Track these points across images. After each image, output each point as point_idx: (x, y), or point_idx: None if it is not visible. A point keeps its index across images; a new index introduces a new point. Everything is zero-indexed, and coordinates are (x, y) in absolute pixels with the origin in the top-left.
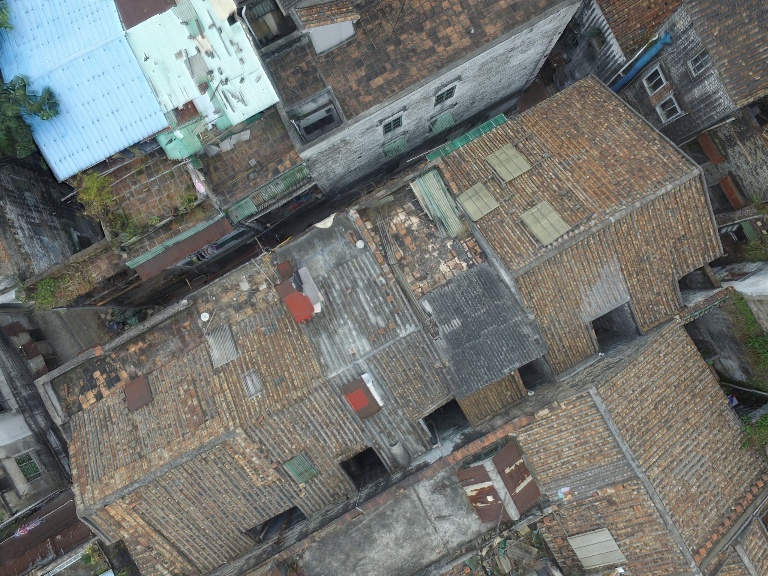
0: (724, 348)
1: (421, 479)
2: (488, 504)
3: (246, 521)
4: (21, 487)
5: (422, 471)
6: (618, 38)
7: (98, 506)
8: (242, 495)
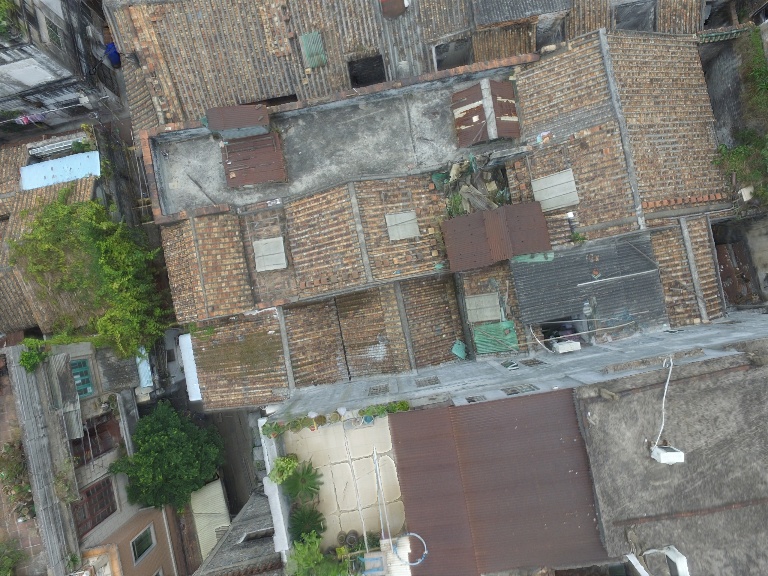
0: (722, 114)
1: (420, 81)
2: (472, 125)
3: (246, 92)
4: (44, 37)
5: (423, 74)
6: None
7: (124, 3)
8: (252, 59)
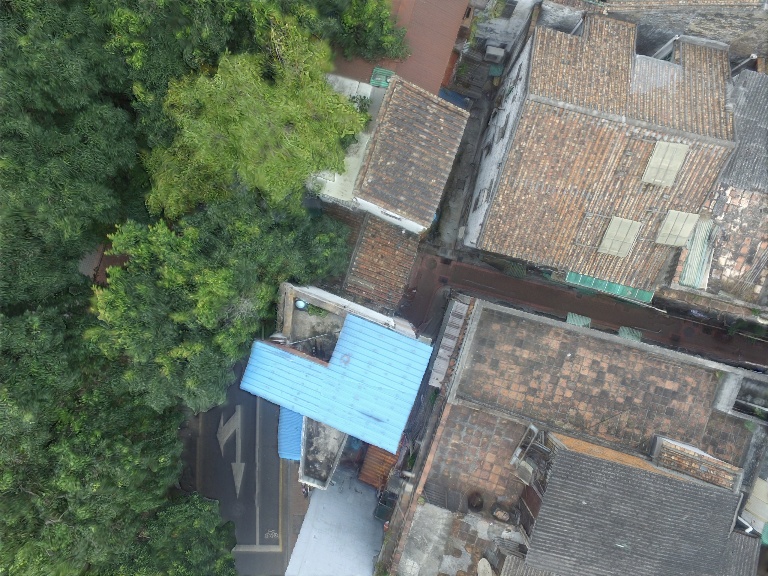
0: None
1: None
2: None
3: None
4: None
5: None
6: None
7: None
8: None
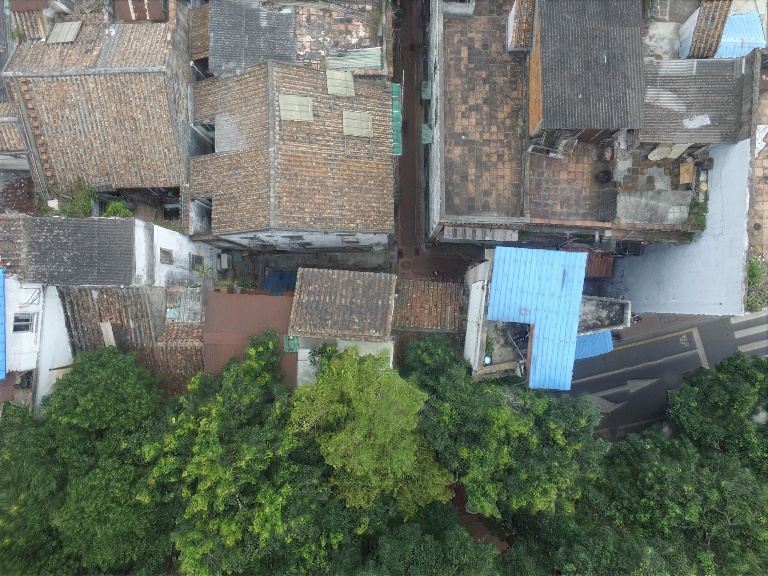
0: None
1: None
2: None
3: None
4: None
5: None
6: (415, 281)
7: None
8: None
